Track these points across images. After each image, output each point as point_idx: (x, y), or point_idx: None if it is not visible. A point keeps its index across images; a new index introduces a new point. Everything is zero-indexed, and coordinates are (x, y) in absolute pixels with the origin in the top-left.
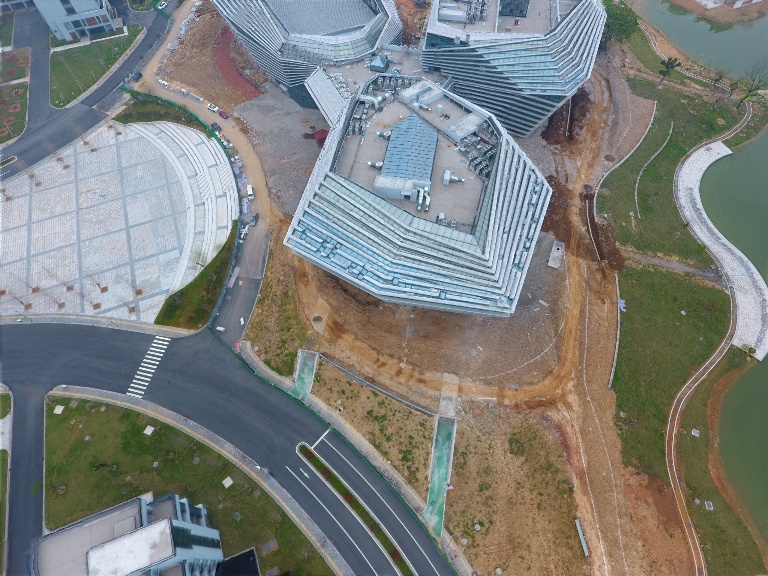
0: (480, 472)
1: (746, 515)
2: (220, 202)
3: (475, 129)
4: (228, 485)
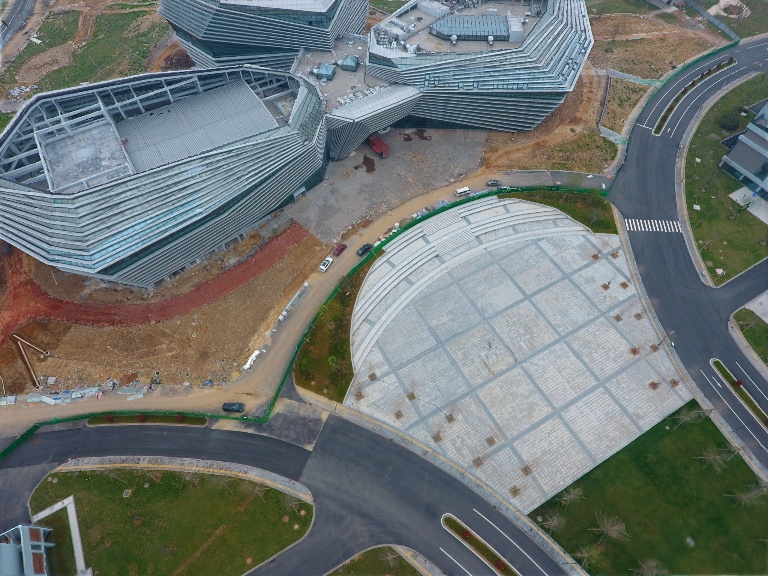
0: (628, 63)
1: (591, 3)
2: (476, 219)
3: (437, 2)
4: (699, 159)
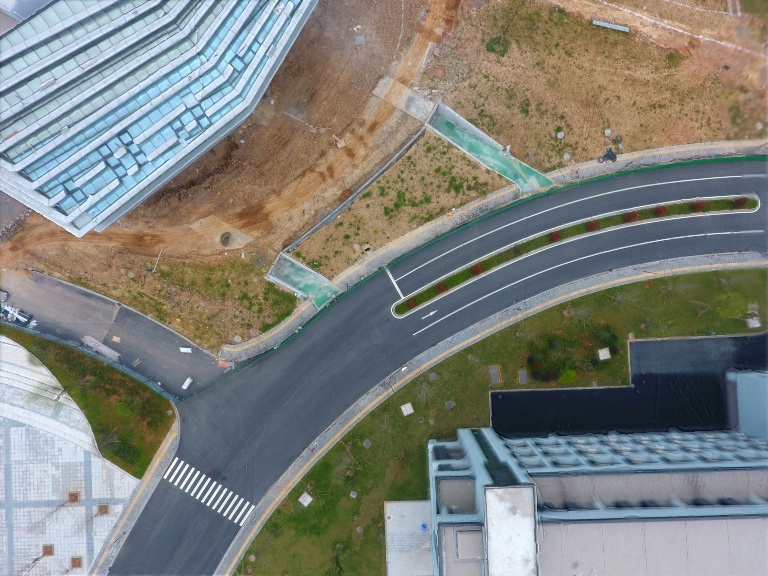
0: (508, 104)
1: None
2: None
3: None
4: (411, 409)
